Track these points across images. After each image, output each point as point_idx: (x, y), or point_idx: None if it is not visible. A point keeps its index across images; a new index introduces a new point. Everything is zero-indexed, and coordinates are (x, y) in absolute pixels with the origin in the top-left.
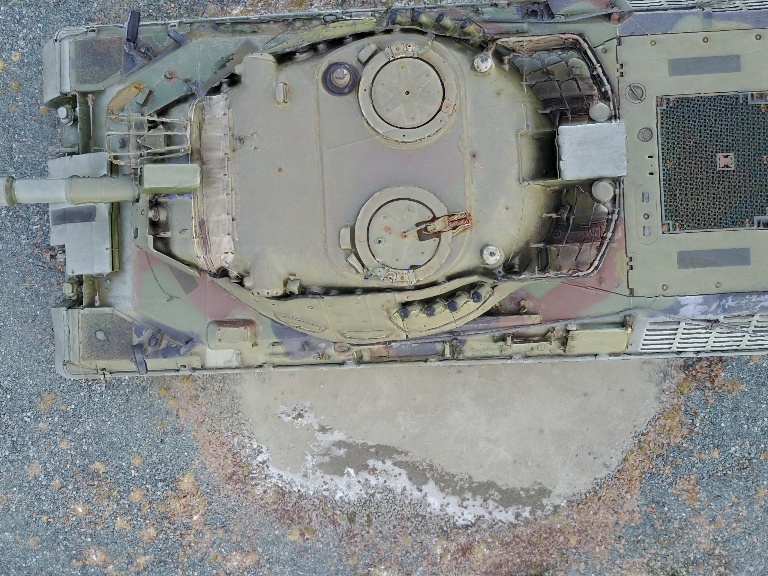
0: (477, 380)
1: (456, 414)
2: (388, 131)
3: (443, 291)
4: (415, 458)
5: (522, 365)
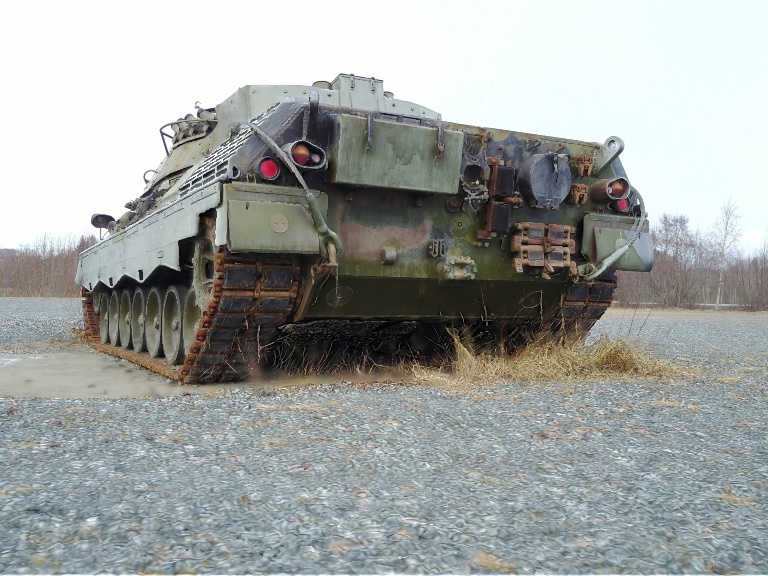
0: None
1: (49, 370)
2: None
3: None
4: None
5: None
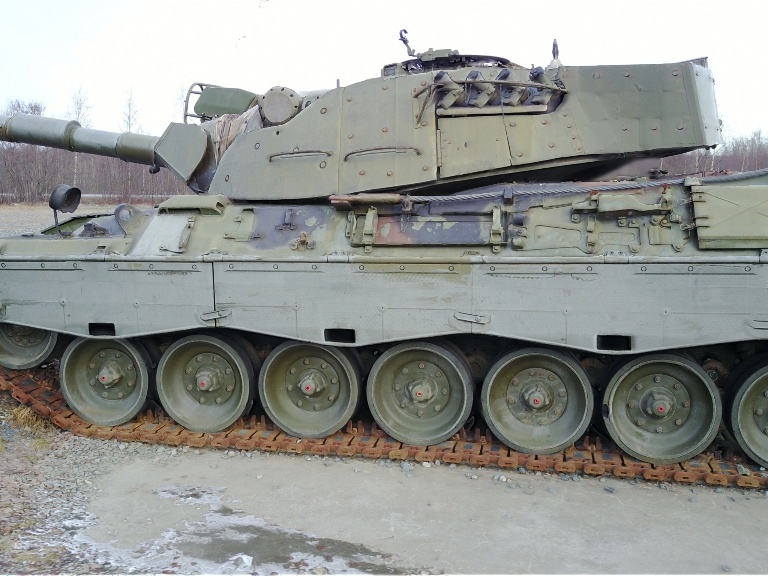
0: (563, 503)
1: (514, 528)
2: None
3: (493, 78)
4: (405, 564)
5: (658, 500)
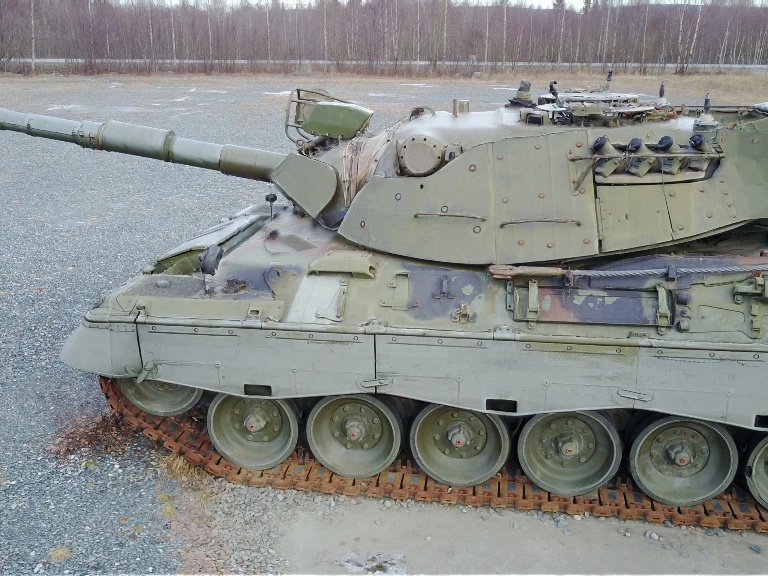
0: (720, 568)
1: None
2: None
3: (650, 140)
4: None
5: None
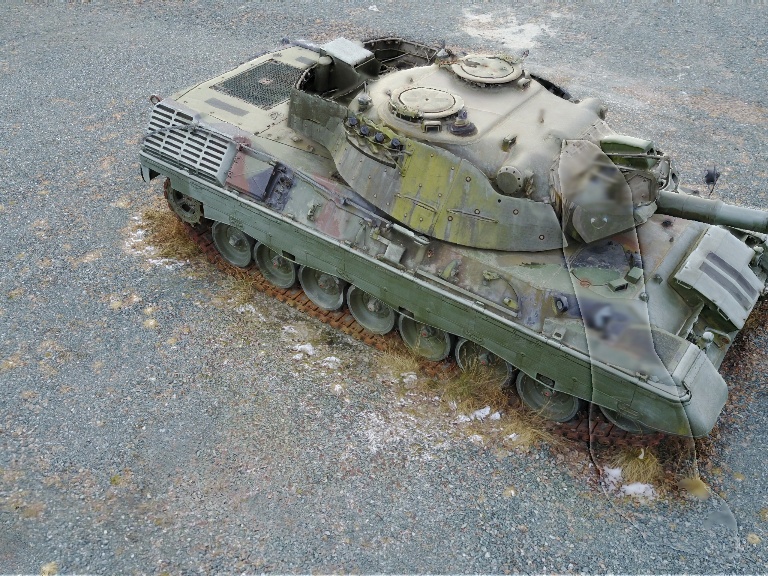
0: None
1: None
2: (456, 95)
3: None
4: None
5: None
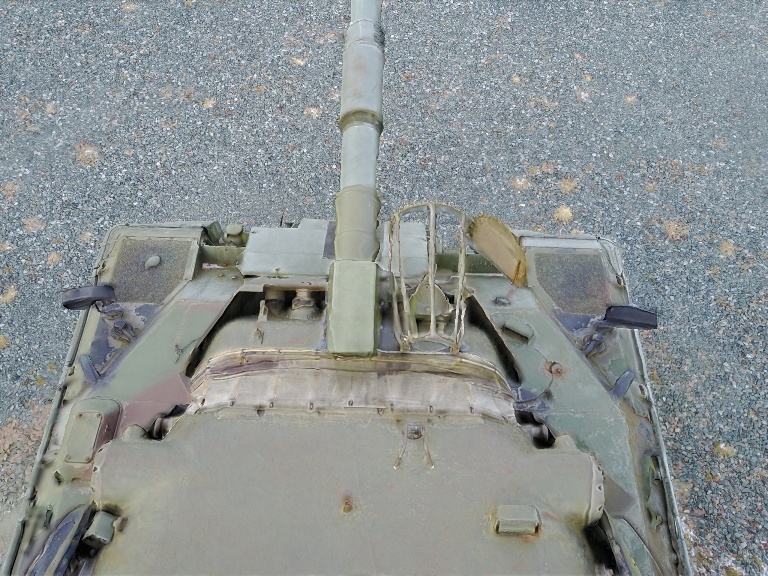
0: None
1: None
2: None
3: None
4: None
5: None
